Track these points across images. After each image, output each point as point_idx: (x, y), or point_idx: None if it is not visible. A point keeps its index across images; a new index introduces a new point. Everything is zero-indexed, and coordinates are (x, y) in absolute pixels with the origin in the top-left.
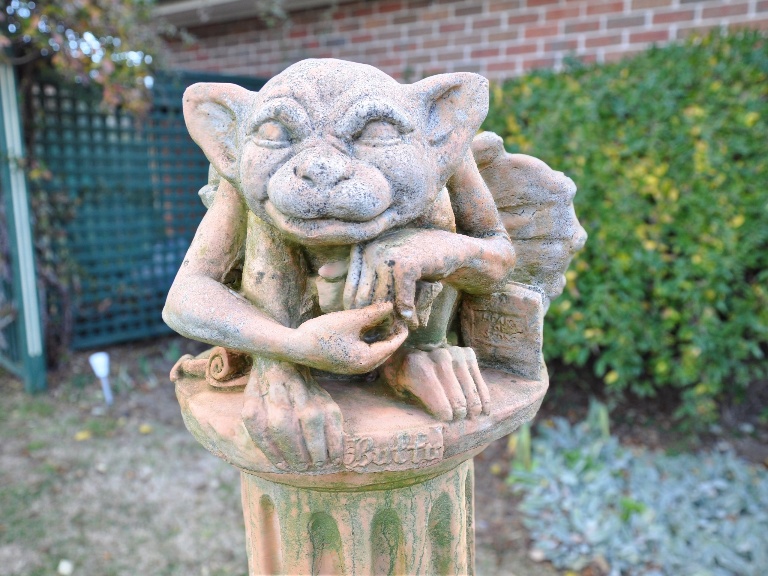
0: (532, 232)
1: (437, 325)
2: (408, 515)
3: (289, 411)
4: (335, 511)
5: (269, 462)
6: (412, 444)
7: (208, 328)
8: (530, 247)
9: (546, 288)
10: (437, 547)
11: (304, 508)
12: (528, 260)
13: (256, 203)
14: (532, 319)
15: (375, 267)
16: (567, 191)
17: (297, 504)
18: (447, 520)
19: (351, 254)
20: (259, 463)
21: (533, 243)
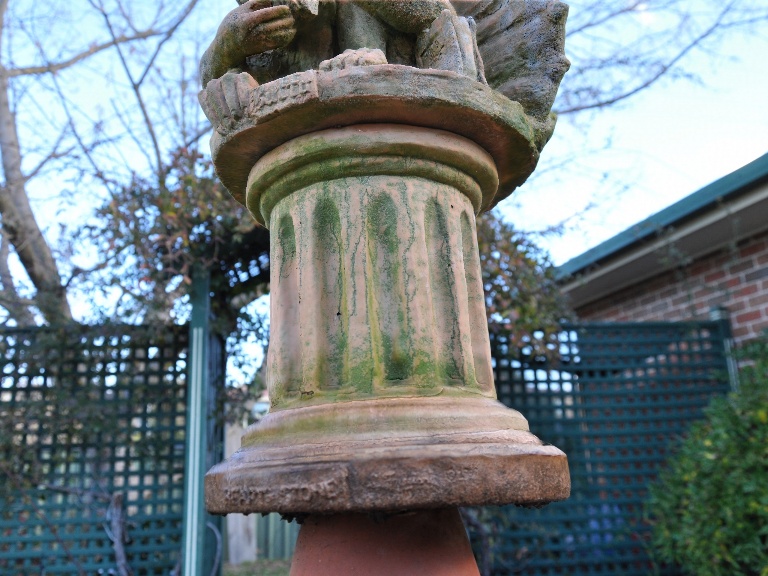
0: (511, 18)
1: (355, 42)
2: (342, 202)
3: (217, 79)
4: None
5: (219, 136)
6: (289, 82)
7: None
8: (514, 32)
9: (541, 66)
10: (389, 255)
11: None
12: (515, 44)
13: None
14: (446, 28)
15: None
16: None
17: None
18: (395, 226)
19: None
20: (216, 140)
21: (517, 29)
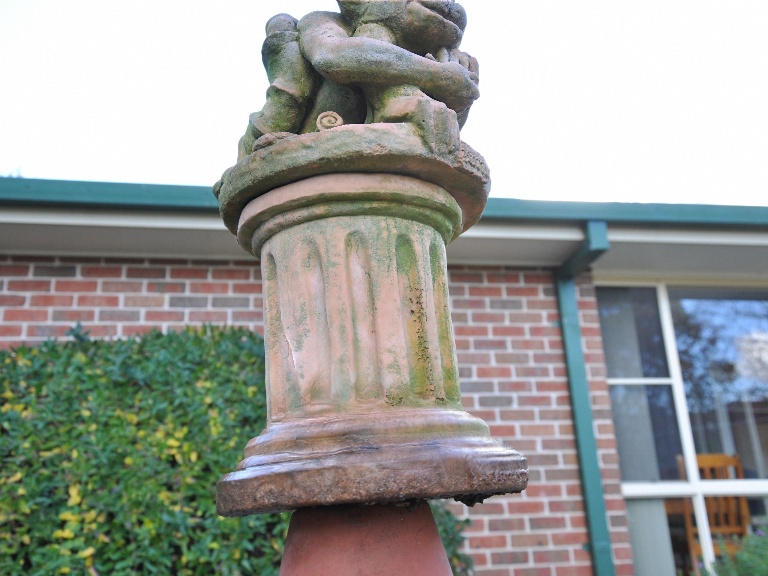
0: None
1: None
2: None
3: None
4: (412, 234)
5: (422, 146)
6: (482, 160)
7: (388, 52)
8: None
9: None
10: None
11: (393, 230)
12: None
13: (404, 2)
14: None
15: (459, 57)
16: None
17: (387, 228)
18: None
19: (442, 52)
20: (416, 145)
21: None
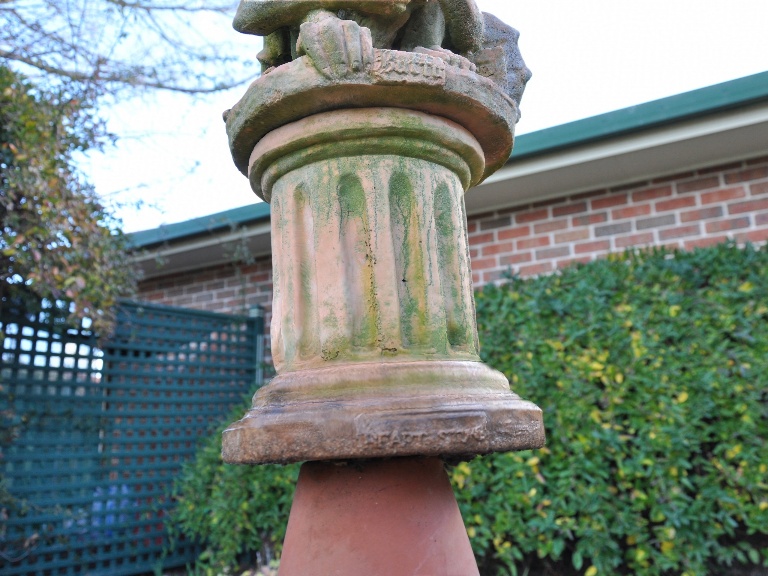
0: None
1: (432, 38)
2: (418, 181)
3: (335, 20)
4: (360, 171)
5: (316, 76)
6: (423, 61)
7: None
8: None
9: None
10: (442, 237)
11: (334, 173)
12: None
13: None
14: (499, 61)
15: None
16: (514, 31)
17: (328, 172)
18: (449, 213)
19: None
20: (309, 78)
21: None
